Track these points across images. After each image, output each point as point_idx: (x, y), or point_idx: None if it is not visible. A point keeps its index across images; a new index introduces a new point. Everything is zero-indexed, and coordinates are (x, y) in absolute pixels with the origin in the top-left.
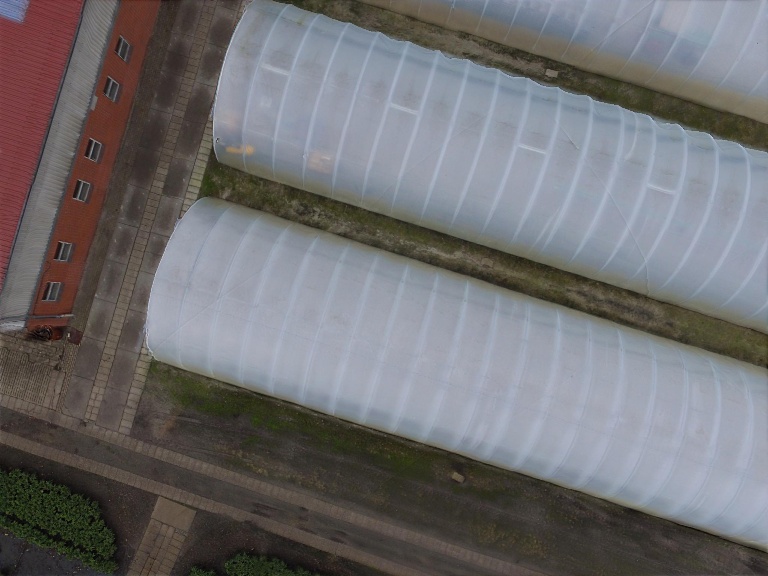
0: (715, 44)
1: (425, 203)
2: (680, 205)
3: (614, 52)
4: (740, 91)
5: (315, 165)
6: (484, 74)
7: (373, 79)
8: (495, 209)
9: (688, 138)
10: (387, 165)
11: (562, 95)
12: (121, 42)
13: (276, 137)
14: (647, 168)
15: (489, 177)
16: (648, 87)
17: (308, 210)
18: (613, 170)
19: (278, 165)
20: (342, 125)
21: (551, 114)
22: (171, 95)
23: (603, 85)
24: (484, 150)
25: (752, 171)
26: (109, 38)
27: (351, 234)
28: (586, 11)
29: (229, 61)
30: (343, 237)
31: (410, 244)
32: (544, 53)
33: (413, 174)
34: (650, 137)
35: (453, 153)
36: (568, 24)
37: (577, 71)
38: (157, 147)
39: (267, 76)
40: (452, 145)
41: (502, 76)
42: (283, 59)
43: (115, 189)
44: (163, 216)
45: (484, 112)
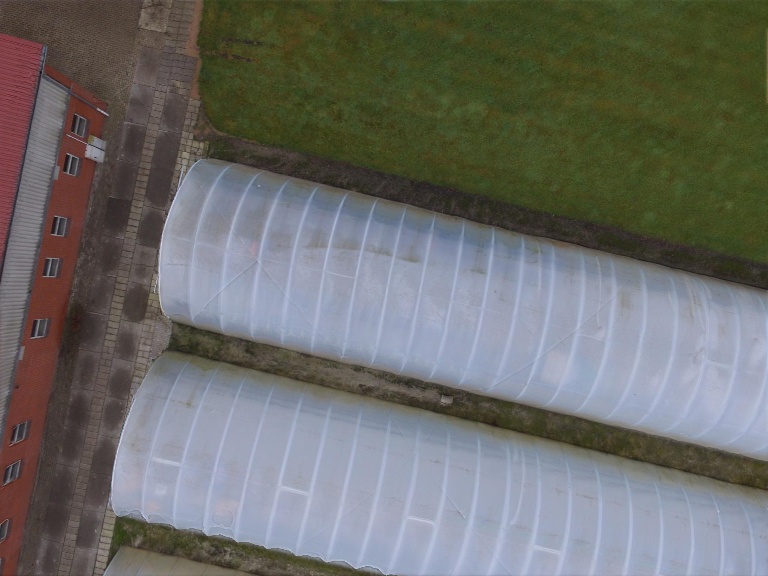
0: (595, 395)
1: (326, 560)
2: (565, 565)
3: (502, 391)
4: (626, 420)
5: (221, 512)
6: (374, 435)
7: (262, 465)
8: (392, 569)
9: (573, 487)
10: (284, 536)
11: (450, 451)
12: (17, 428)
13: (175, 517)
14: (532, 532)
15: (382, 546)
16: (541, 408)
17: (219, 550)
18: (499, 537)
19: (182, 528)
20: (236, 509)
21: (438, 482)
22: (76, 449)
23: (497, 407)
24: (374, 526)
25: (634, 520)
26: (1, 443)
27: (262, 570)
28: (469, 369)
29: (120, 460)
30: (255, 575)
31: (320, 575)
32: (438, 381)
33: (310, 544)
34: (535, 495)
35: (345, 529)
36: (454, 375)
37: (471, 395)
38: (67, 501)
39: (159, 471)
40: (343, 523)
41: (392, 435)
42: (173, 452)
43: (29, 545)
44: (78, 567)
45: (372, 489)
